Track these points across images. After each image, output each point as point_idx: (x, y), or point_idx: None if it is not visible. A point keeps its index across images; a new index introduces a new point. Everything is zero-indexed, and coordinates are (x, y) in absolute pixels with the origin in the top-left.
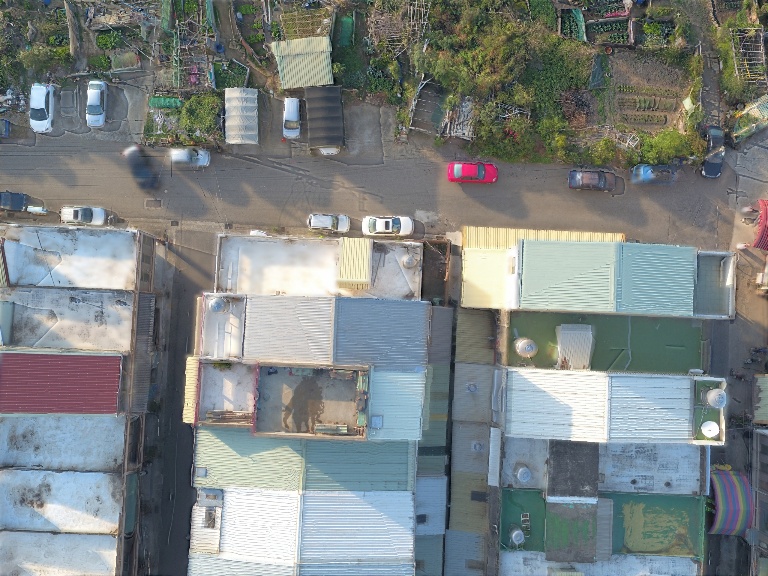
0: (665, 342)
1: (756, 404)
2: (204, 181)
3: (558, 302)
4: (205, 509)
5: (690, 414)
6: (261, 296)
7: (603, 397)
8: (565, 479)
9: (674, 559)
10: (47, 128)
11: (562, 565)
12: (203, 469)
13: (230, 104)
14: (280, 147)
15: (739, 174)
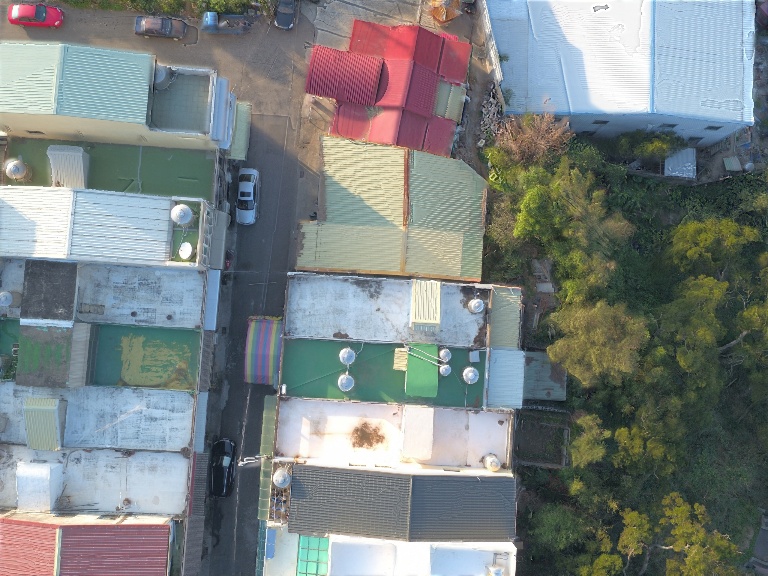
0: (177, 174)
1: (299, 251)
2: None
3: (1, 105)
4: None
5: (168, 236)
6: None
7: (67, 212)
8: (38, 301)
9: (173, 394)
10: None
11: (53, 397)
12: None
13: None
14: None
15: (318, 28)
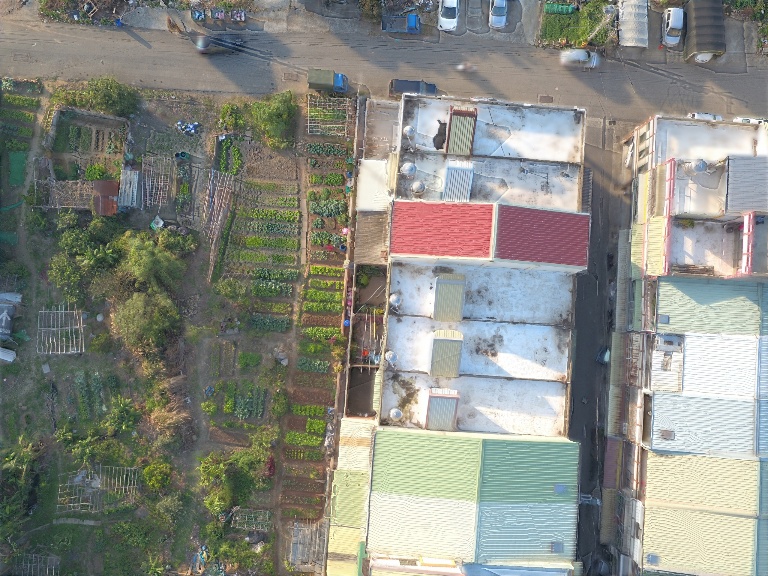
0: None
1: None
2: (591, 81)
3: None
4: (664, 354)
5: None
6: (744, 157)
7: None
8: None
9: None
10: (454, 26)
11: None
12: (666, 316)
13: (624, 11)
14: (656, 54)
15: None
